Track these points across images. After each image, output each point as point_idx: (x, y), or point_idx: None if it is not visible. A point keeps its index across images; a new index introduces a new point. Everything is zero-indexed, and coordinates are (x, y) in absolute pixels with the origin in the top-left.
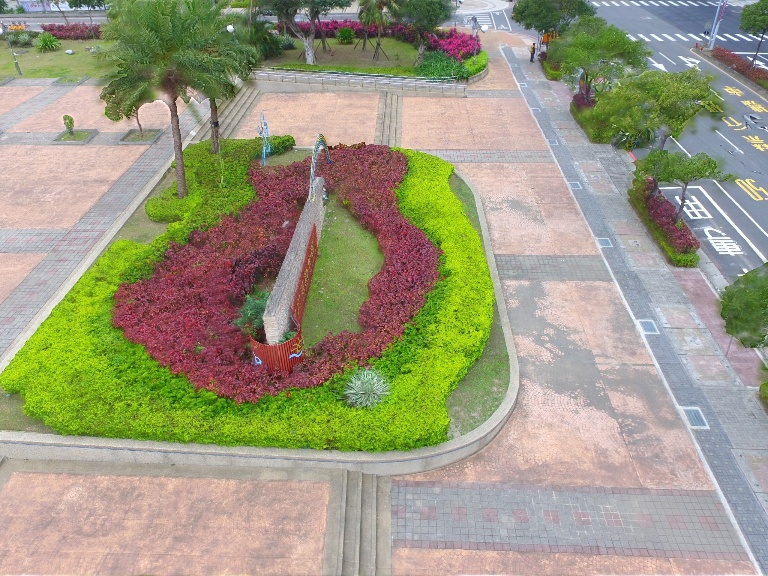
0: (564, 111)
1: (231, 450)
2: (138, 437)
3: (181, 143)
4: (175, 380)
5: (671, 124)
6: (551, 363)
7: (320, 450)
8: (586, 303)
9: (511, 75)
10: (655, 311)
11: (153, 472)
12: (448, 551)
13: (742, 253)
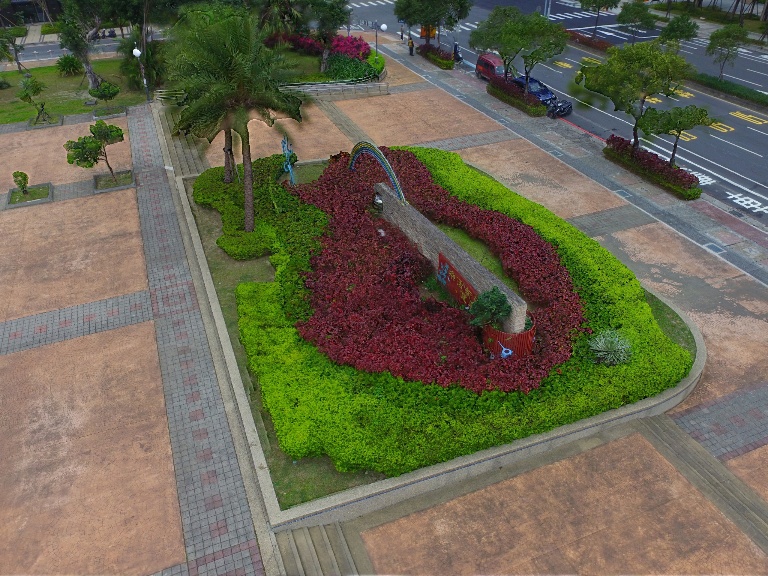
0: (484, 94)
1: (552, 434)
2: (468, 452)
3: None
4: (454, 391)
5: (665, 85)
6: (681, 293)
7: (617, 408)
8: (658, 242)
9: (408, 69)
10: (707, 236)
11: (491, 480)
12: (760, 450)
13: (715, 181)
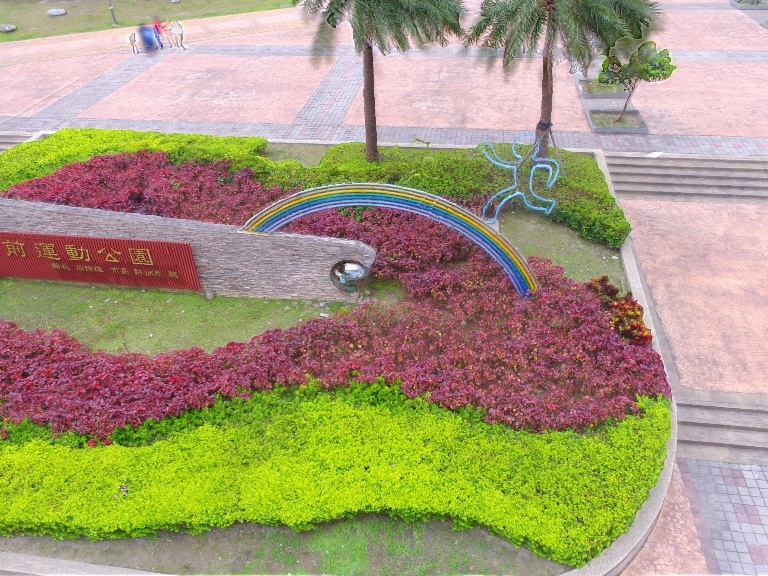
0: None
1: None
2: None
3: (369, 89)
4: None
5: None
6: None
7: None
8: None
9: None
10: None
11: None
12: None
13: None
